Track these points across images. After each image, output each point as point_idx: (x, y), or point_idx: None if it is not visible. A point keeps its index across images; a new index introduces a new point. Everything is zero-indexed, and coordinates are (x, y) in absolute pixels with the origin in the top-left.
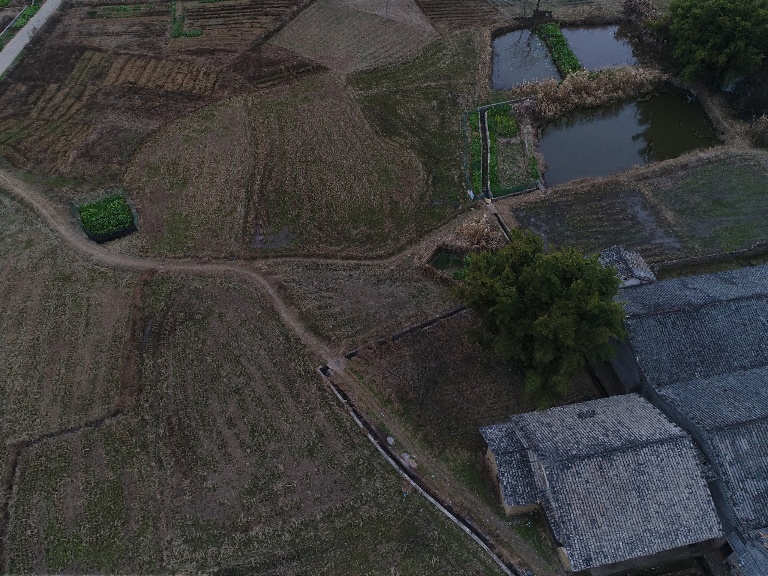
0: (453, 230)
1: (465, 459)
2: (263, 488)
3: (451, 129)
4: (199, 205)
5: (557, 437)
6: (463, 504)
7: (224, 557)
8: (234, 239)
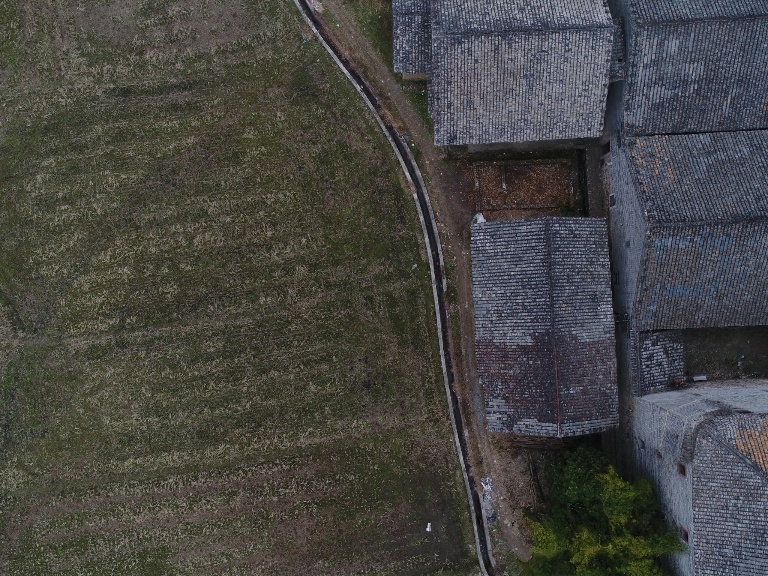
0: None
1: (377, 11)
2: (158, 10)
3: None
4: None
5: (466, 4)
6: (362, 61)
7: (119, 76)
8: None
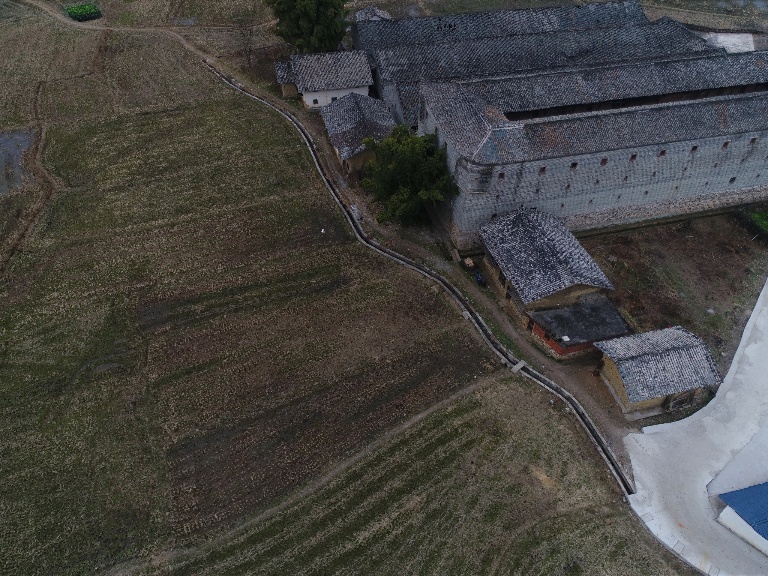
0: None
1: (270, 85)
2: None
3: None
4: (141, 8)
5: None
6: None
7: None
8: (161, 21)
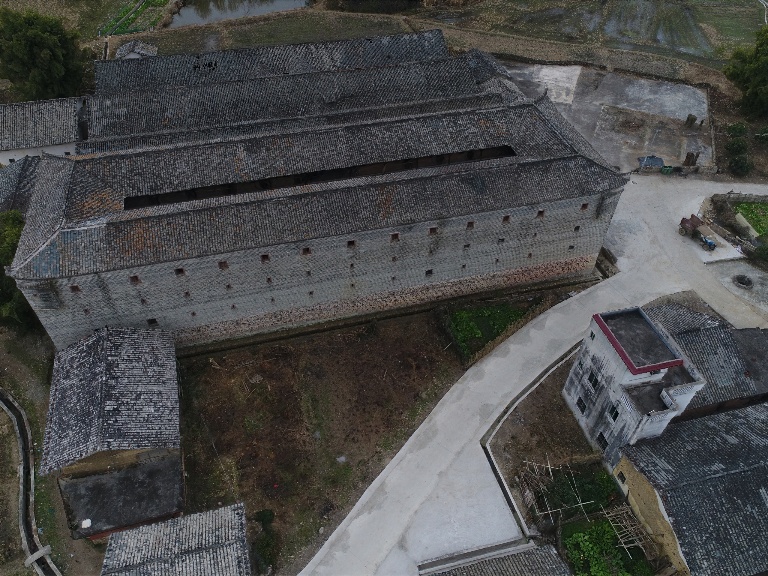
0: None
1: None
2: None
3: (119, 3)
4: None
5: None
6: None
7: None
8: None
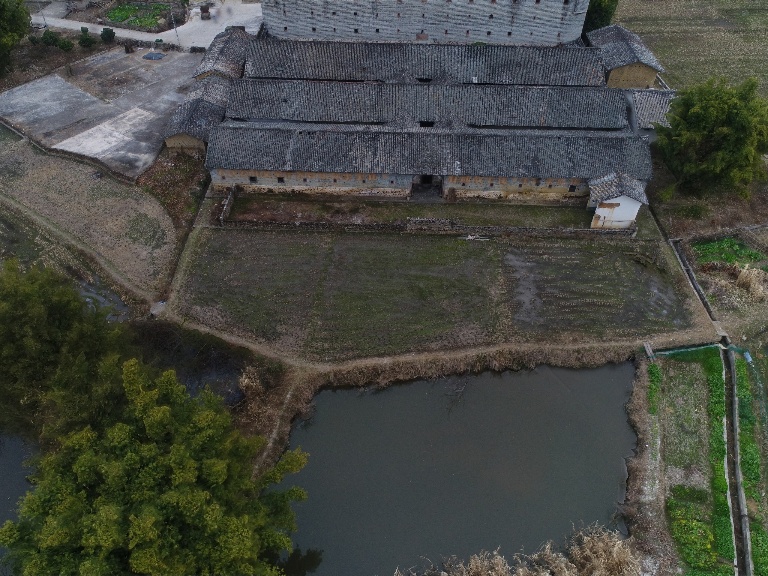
0: (767, 306)
1: None
2: None
3: None
4: None
5: None
6: None
7: None
8: None
